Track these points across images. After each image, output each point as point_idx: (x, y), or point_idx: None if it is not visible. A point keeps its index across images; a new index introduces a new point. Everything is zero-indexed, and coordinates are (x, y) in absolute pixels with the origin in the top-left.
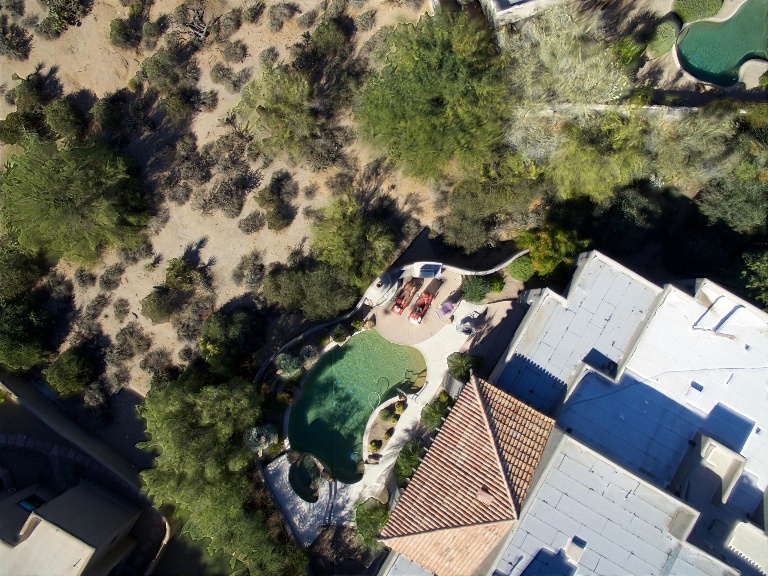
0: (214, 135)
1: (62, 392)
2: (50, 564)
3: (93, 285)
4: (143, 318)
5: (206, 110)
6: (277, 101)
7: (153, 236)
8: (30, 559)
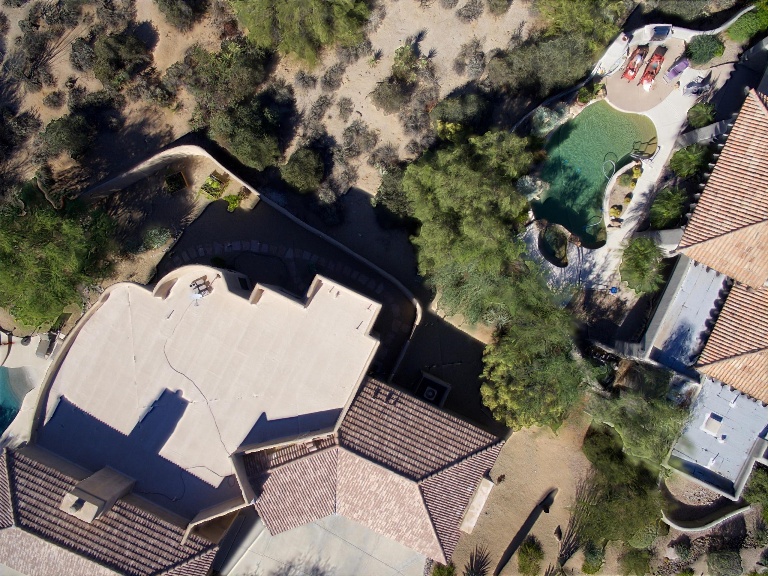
0: None
1: (302, 187)
2: (332, 329)
3: (314, 88)
4: (368, 115)
5: None
6: None
7: (371, 33)
8: (312, 327)
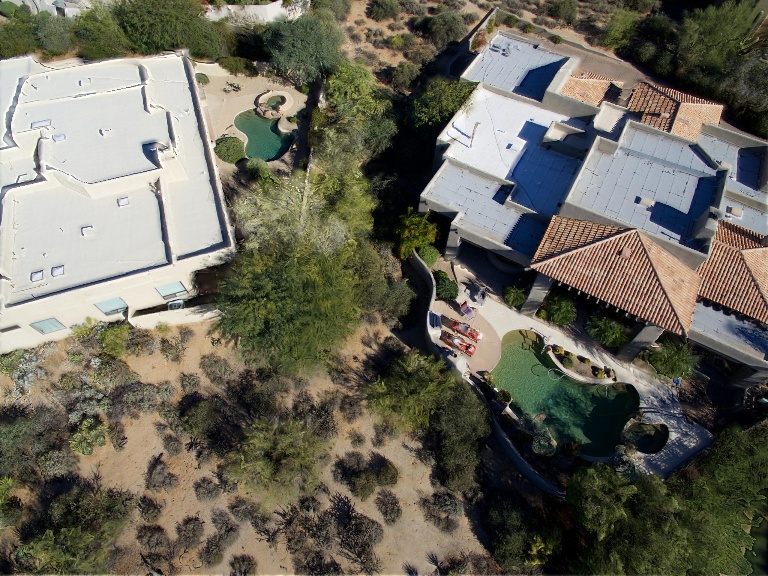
0: (285, 559)
1: None
2: None
3: None
4: None
5: (254, 570)
6: (269, 457)
7: None
8: None
